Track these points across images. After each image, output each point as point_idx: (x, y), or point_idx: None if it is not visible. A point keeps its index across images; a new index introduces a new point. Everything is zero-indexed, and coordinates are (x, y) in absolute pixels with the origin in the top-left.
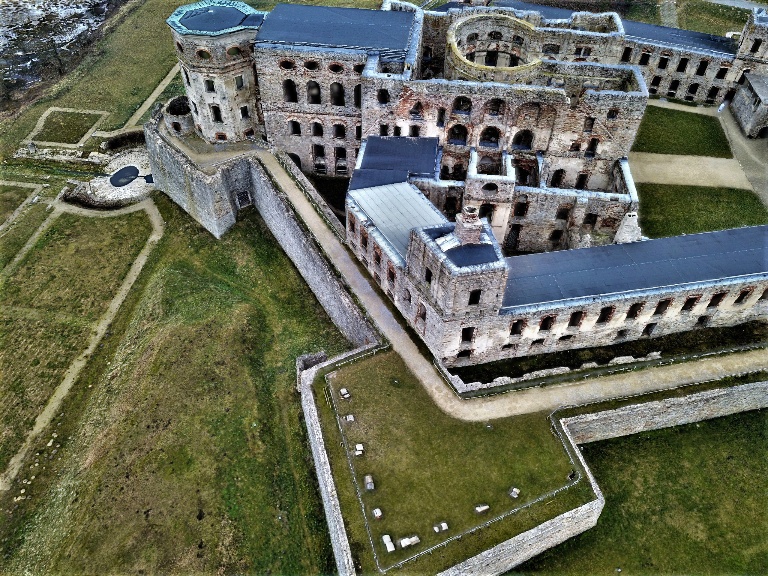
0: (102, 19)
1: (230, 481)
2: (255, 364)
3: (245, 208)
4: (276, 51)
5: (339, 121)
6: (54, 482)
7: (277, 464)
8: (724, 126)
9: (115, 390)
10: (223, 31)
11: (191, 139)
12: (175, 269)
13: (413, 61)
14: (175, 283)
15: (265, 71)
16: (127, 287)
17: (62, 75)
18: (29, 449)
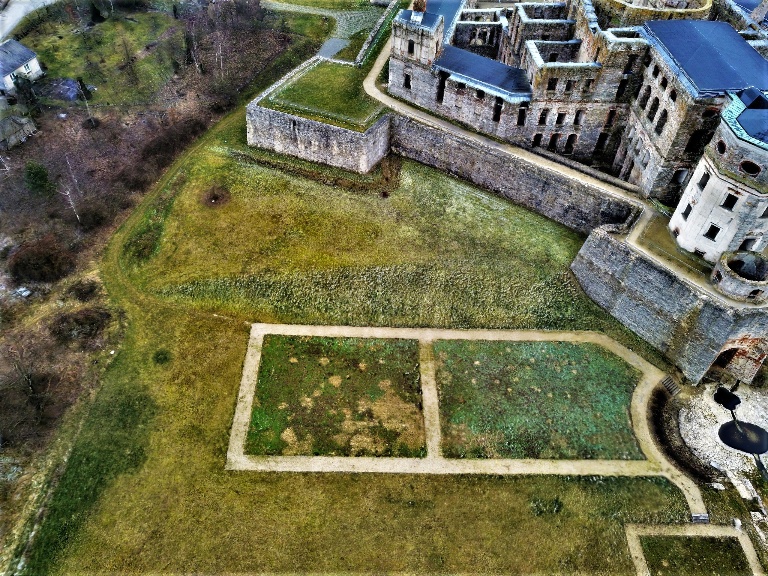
0: None
1: None
2: None
3: None
4: None
5: None
6: None
7: None
8: (508, 7)
9: None
10: None
11: None
12: None
13: None
14: None
15: None
16: None
17: None
18: None
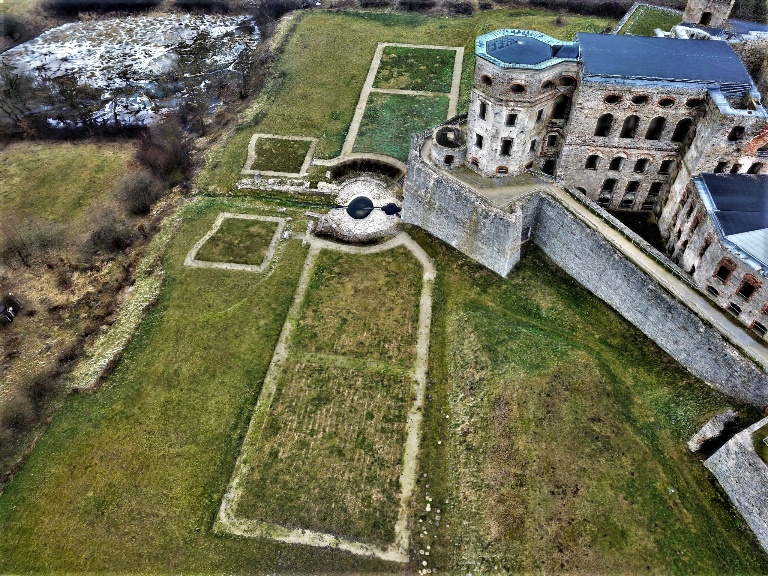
0: (256, 38)
1: (674, 555)
2: (630, 420)
3: (523, 244)
4: (606, 85)
5: (646, 155)
6: (456, 553)
7: (710, 535)
8: None
9: (478, 448)
10: (543, 64)
11: (463, 172)
12: (473, 311)
13: (759, 95)
14: (485, 327)
15: (585, 105)
16: (426, 331)
17: (244, 98)
18: (409, 515)
